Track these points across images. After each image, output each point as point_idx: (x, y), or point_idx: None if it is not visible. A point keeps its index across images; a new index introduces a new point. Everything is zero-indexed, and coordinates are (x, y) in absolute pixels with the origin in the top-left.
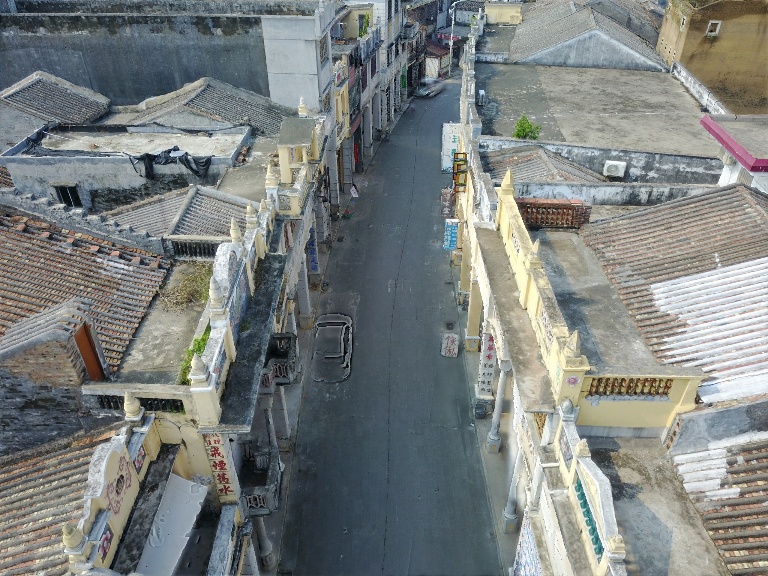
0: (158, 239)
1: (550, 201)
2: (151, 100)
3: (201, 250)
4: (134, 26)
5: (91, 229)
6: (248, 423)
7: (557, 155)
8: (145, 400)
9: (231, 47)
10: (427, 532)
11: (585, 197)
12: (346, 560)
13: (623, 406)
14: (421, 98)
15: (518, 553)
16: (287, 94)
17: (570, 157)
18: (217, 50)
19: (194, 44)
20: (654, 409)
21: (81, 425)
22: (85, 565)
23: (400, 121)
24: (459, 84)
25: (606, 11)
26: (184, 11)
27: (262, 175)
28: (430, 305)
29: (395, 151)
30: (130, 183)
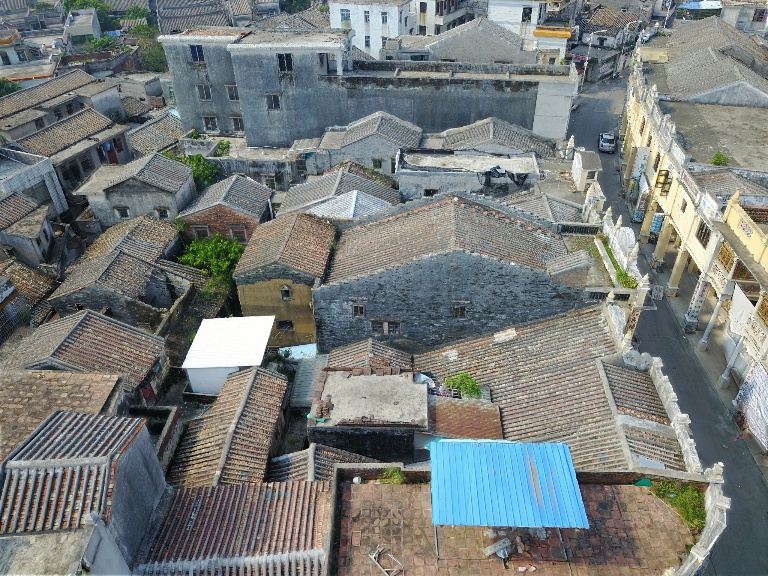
0: (557, 224)
1: (758, 207)
2: (451, 130)
3: (576, 230)
4: (453, 85)
5: (524, 218)
6: (655, 306)
7: (740, 176)
8: None
9: (514, 99)
10: (676, 387)
11: (764, 203)
12: None
13: None
14: None
15: (743, 388)
16: (544, 129)
17: (748, 177)
18: (504, 101)
19: (490, 97)
20: None
21: (574, 306)
22: (631, 347)
23: None
24: (592, 98)
25: (736, 55)
26: (468, 70)
27: (561, 186)
28: None
29: None
30: (472, 188)
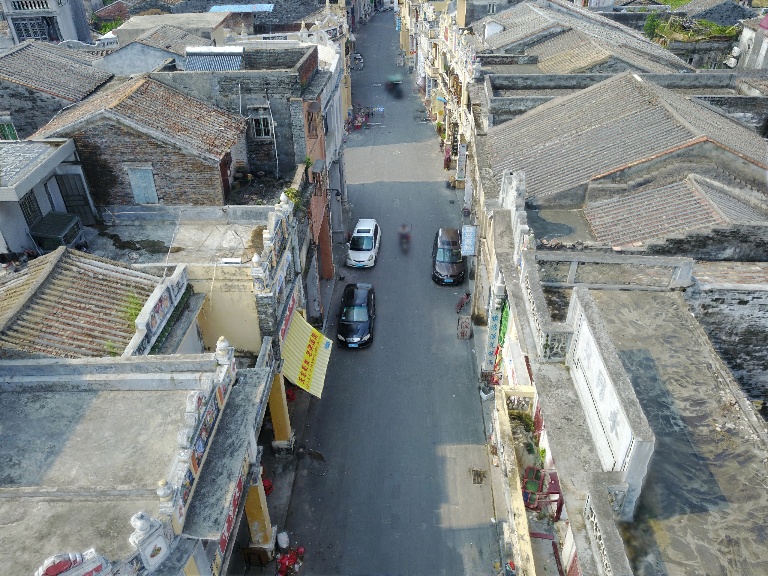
0: None
1: None
2: None
3: None
4: None
5: None
6: None
7: None
8: (329, 0)
9: None
10: None
11: None
12: (370, 90)
13: (436, 4)
14: (382, 11)
15: None
16: None
17: None
18: None
19: None
20: (443, 5)
21: (312, 11)
22: None
23: (371, 19)
24: None
25: None
26: None
27: None
28: (392, 59)
29: (370, 27)
30: None
